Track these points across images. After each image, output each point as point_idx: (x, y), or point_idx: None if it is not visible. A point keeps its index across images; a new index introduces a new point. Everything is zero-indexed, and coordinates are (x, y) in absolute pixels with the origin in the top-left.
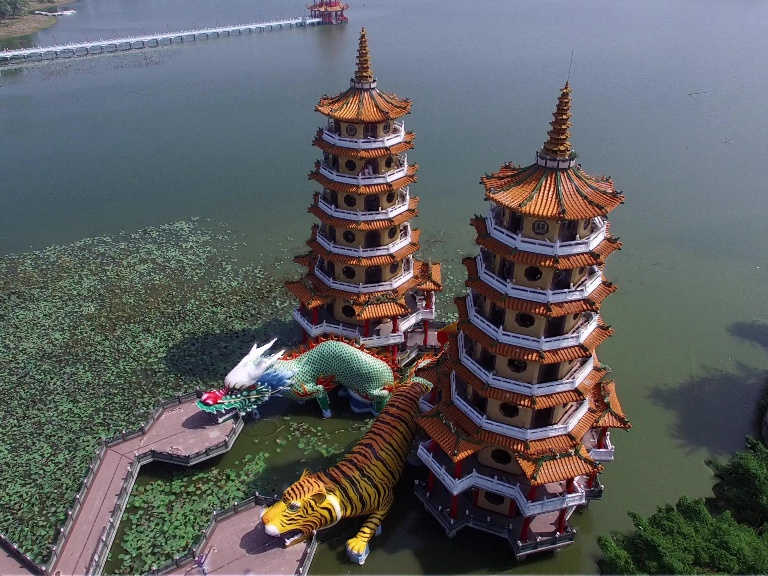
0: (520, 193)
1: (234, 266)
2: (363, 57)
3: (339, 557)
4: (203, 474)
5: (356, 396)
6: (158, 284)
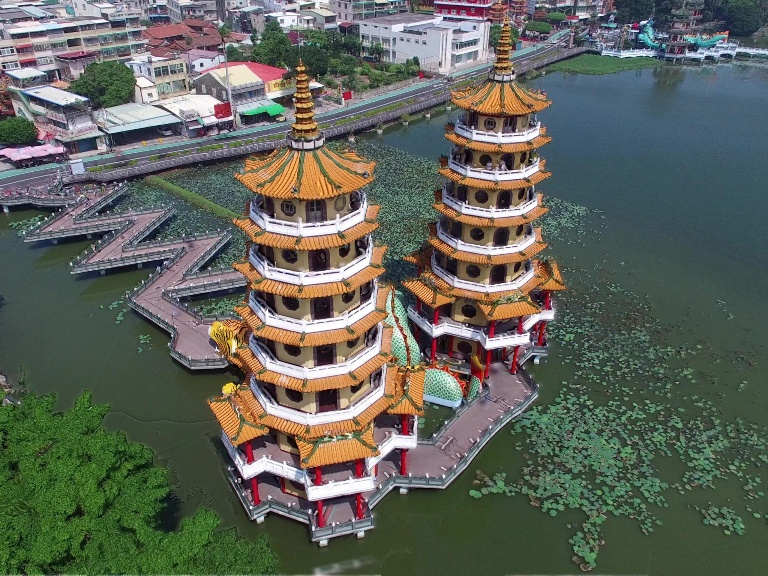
0: None
1: None
2: (499, 47)
3: None
4: None
5: None
6: None
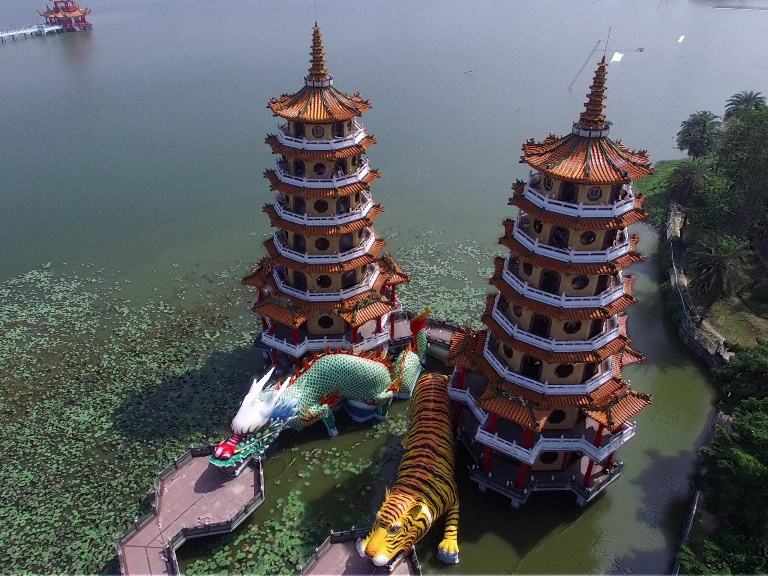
0: (574, 165)
1: (131, 308)
2: (319, 54)
3: (433, 564)
4: (243, 536)
5: (361, 405)
6: (49, 348)
